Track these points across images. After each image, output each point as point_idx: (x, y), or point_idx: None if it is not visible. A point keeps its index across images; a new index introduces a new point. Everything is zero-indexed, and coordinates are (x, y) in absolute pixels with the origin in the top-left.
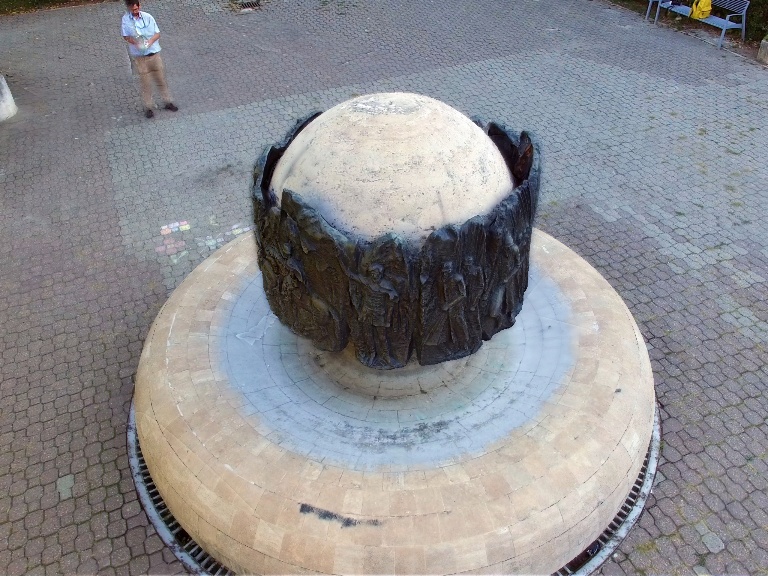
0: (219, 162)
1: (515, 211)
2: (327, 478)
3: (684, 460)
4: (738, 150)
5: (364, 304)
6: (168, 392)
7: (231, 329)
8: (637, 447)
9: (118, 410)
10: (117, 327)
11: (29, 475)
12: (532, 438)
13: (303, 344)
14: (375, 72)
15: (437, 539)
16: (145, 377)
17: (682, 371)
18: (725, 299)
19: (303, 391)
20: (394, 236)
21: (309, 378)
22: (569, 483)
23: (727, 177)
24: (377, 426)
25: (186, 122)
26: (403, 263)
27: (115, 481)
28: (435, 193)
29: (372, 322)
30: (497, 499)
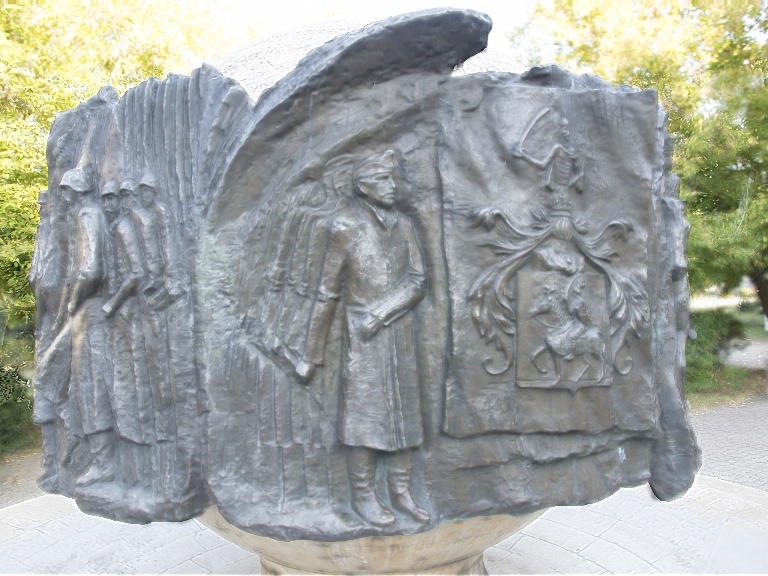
0: None
1: None
2: None
3: None
4: None
5: None
6: None
7: None
8: None
9: None
10: None
11: None
12: None
13: None
14: None
15: None
16: None
17: None
18: None
19: (229, 543)
20: None
21: None
22: None
23: None
24: None
25: None
26: None
27: None
28: None
29: None
30: None
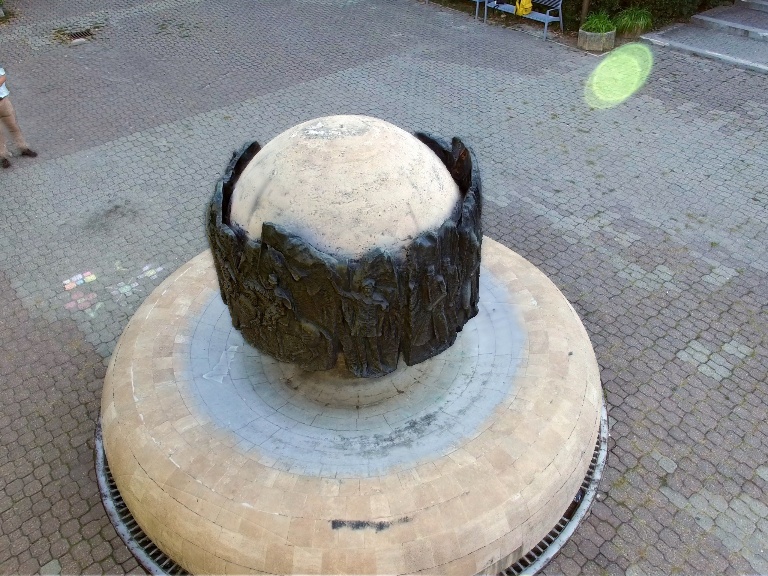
0: (104, 204)
1: (474, 211)
2: (347, 491)
3: (626, 402)
4: (587, 129)
5: (357, 319)
6: (155, 447)
7: (195, 371)
8: (597, 399)
9: (84, 481)
10: (50, 396)
11: (4, 573)
12: (515, 410)
13: (270, 371)
14: (240, 92)
15: (464, 519)
16: (121, 438)
17: (602, 327)
18: (616, 259)
19: (288, 416)
20: (383, 250)
21: (288, 403)
22: (557, 442)
23: (586, 153)
24: (370, 433)
25: (51, 167)
26: (393, 274)
27: (107, 554)
28: (406, 205)
29: (366, 334)
30: (505, 471)
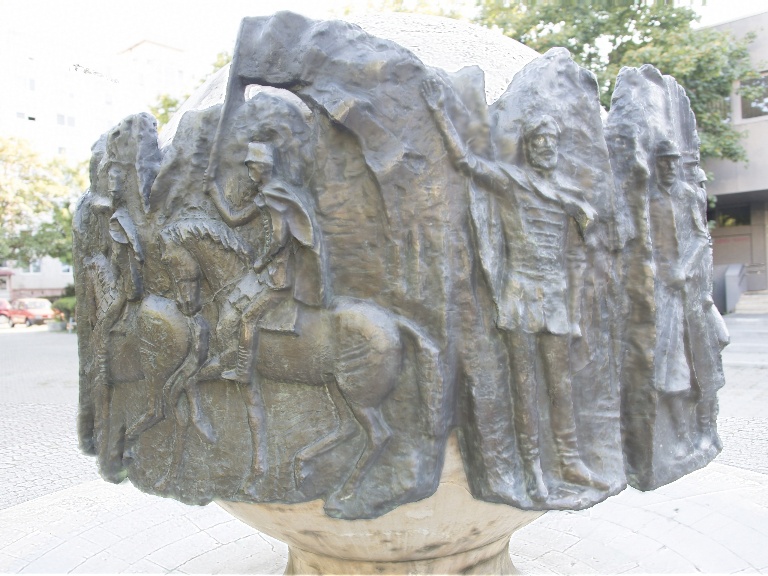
0: None
1: None
2: None
3: None
4: None
5: (512, 264)
6: None
7: None
8: None
9: None
10: None
11: None
12: None
13: None
14: None
15: None
16: None
17: None
18: None
19: None
20: None
21: None
22: None
23: None
24: None
25: None
26: (597, 119)
27: None
28: None
29: (543, 318)
30: None
